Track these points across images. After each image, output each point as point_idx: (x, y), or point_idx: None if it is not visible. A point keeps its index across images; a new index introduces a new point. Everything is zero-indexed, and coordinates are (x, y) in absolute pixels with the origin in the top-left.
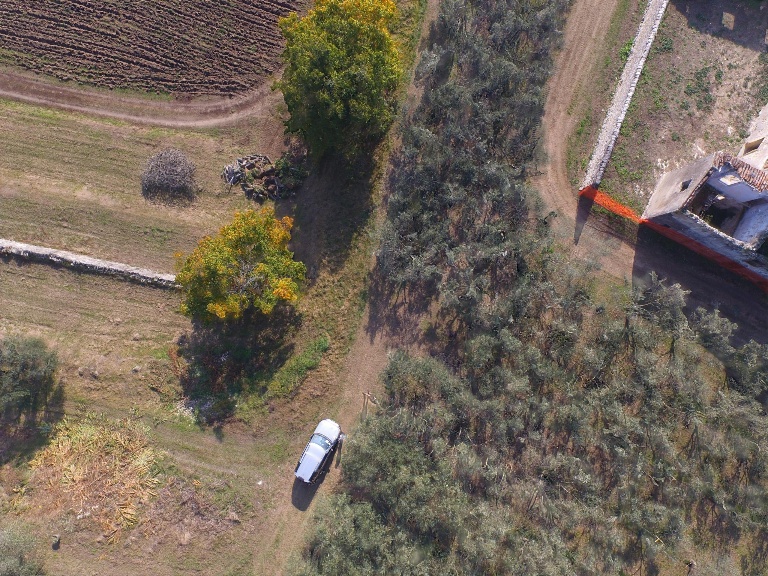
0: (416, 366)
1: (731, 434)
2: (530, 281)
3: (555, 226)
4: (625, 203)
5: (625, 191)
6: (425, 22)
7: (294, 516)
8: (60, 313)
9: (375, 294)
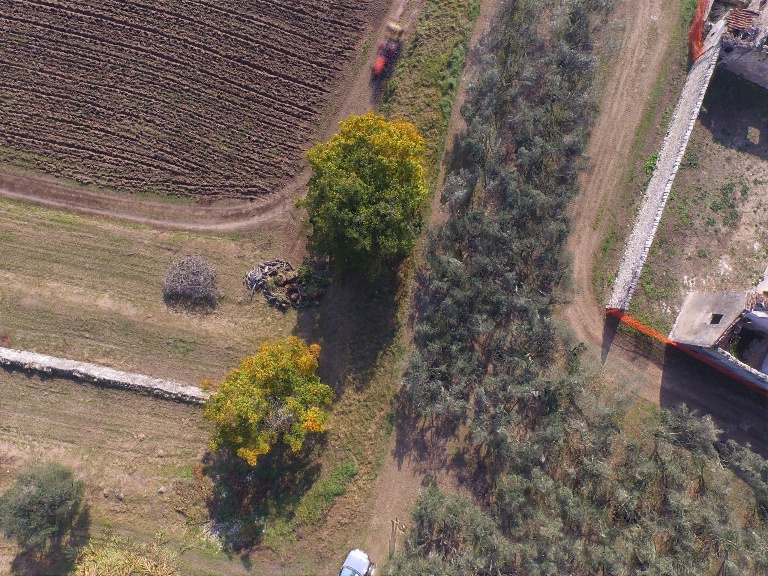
0: (444, 493)
1: (762, 562)
2: (561, 416)
3: None
4: (652, 322)
5: (652, 309)
6: (449, 135)
7: None
8: (83, 429)
9: (402, 417)
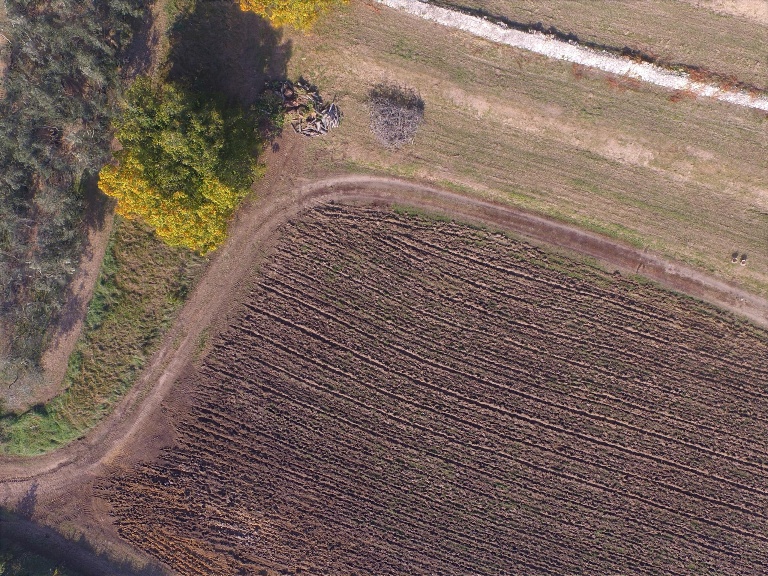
0: None
1: None
2: None
3: None
4: None
5: None
6: (109, 231)
7: None
8: None
9: None
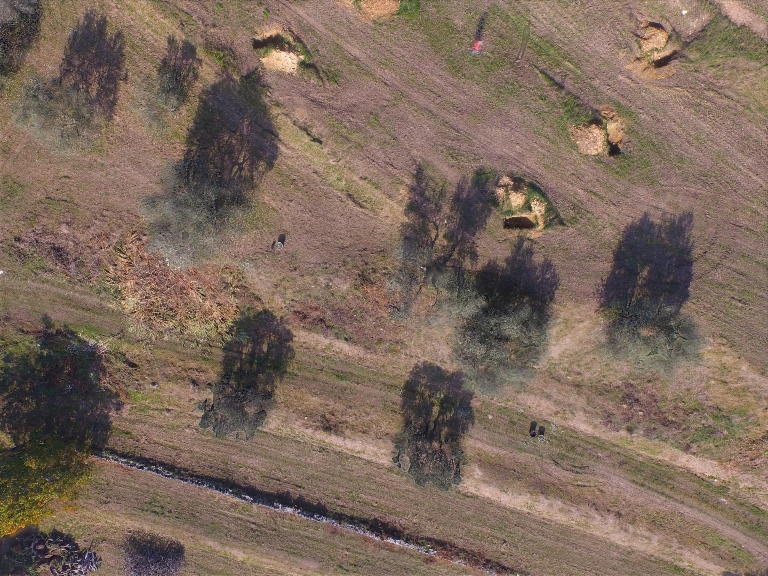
0: None
1: None
2: None
3: None
4: None
5: None
6: None
7: None
8: (247, 442)
9: None
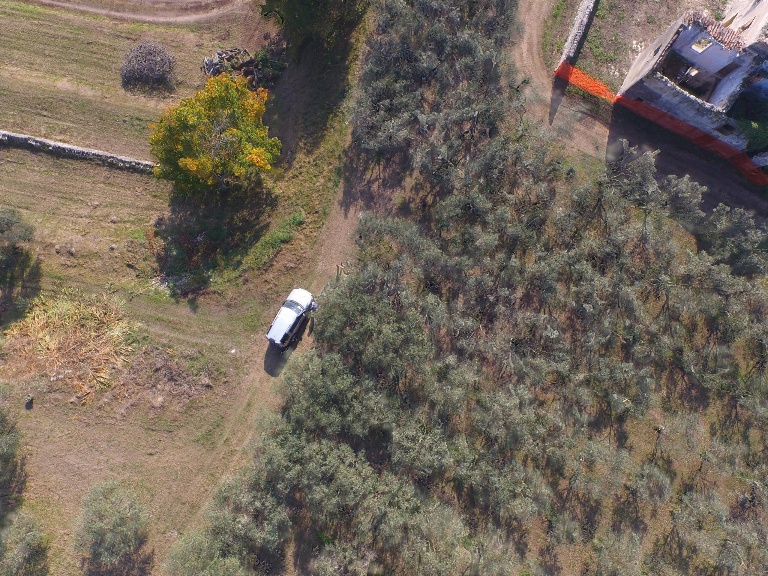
0: (389, 239)
1: (702, 305)
2: (501, 146)
3: (530, 106)
4: (600, 84)
5: (600, 72)
6: None
7: (266, 382)
8: (38, 196)
9: (350, 170)
